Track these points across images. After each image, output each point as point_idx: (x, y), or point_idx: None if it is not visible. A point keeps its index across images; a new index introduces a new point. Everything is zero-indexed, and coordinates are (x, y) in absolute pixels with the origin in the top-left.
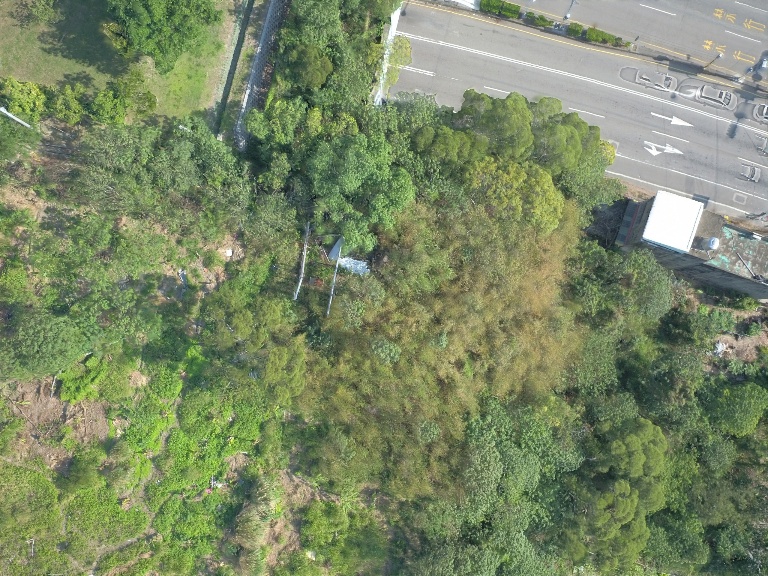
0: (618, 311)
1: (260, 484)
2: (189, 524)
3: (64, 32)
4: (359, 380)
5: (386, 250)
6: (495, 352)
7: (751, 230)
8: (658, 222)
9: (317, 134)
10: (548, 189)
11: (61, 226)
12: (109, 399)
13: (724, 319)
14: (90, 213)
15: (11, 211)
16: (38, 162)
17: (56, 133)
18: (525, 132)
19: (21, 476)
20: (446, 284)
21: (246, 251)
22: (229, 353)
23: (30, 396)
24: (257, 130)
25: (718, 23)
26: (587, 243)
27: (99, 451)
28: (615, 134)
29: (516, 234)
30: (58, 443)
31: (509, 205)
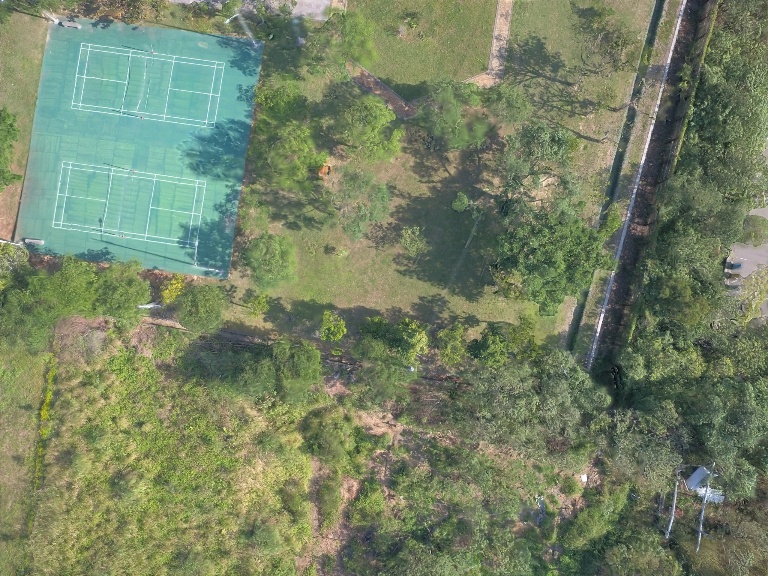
0: None
1: None
2: None
3: (419, 254)
4: None
5: (760, 491)
6: None
7: None
8: None
9: None
10: None
11: (417, 449)
12: None
13: None
14: (446, 437)
15: (370, 435)
16: None
17: None
18: None
19: None
20: None
21: (603, 478)
22: None
23: None
24: (639, 374)
25: None
26: None
27: None
28: None
29: None
30: None
31: None
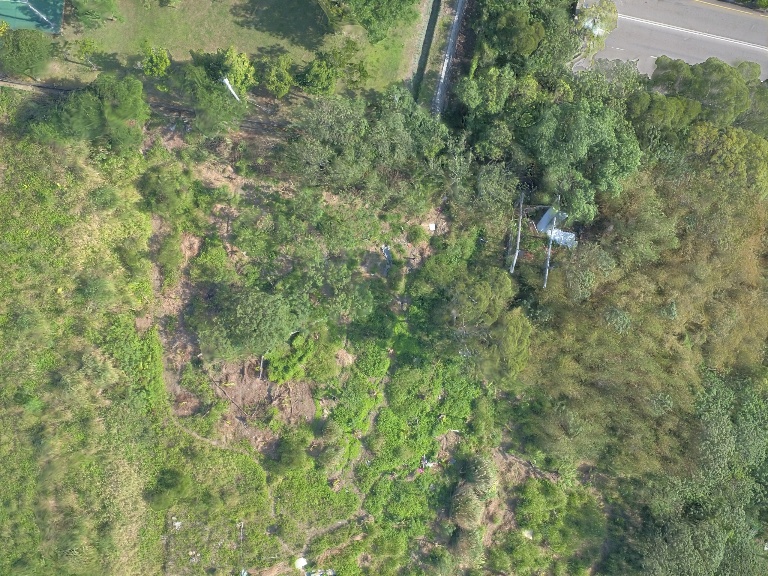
0: None
1: (478, 462)
2: (402, 504)
3: (256, 4)
4: (580, 354)
5: (605, 220)
6: (716, 323)
7: None
8: None
9: (531, 102)
10: None
11: (259, 203)
12: (316, 378)
13: None
14: (289, 189)
15: (209, 189)
16: (236, 138)
17: (252, 108)
18: (745, 95)
19: (228, 458)
20: (668, 254)
21: (451, 225)
22: (438, 329)
23: (234, 377)
24: (473, 99)
25: None
26: None
27: (307, 432)
28: None
29: (745, 200)
30: (265, 424)
31: (735, 170)
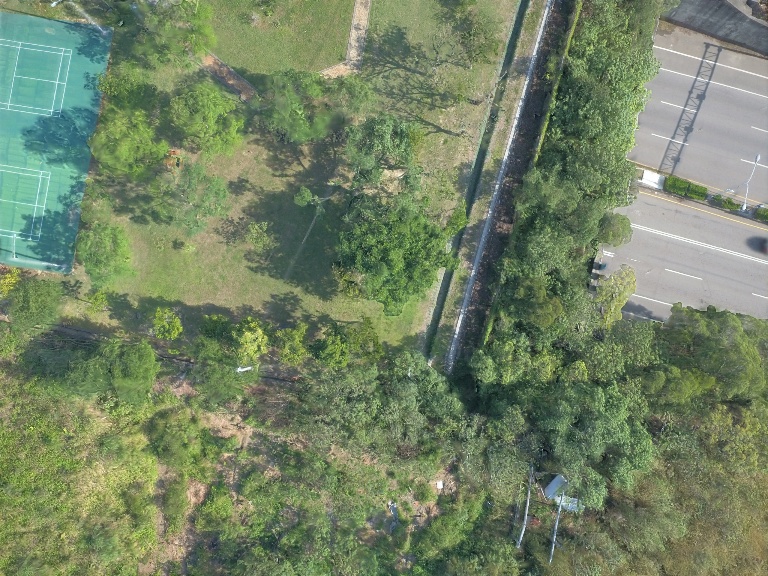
0: None
1: None
2: None
3: (271, 250)
4: None
5: (614, 501)
6: None
7: None
8: None
9: (545, 379)
10: None
11: (267, 453)
12: None
13: None
14: (297, 440)
15: (217, 438)
16: (246, 389)
17: (263, 357)
18: (760, 380)
19: None
20: (675, 537)
21: (459, 485)
22: None
23: None
24: (487, 377)
25: None
26: None
27: None
28: None
29: (755, 494)
30: None
31: (746, 462)
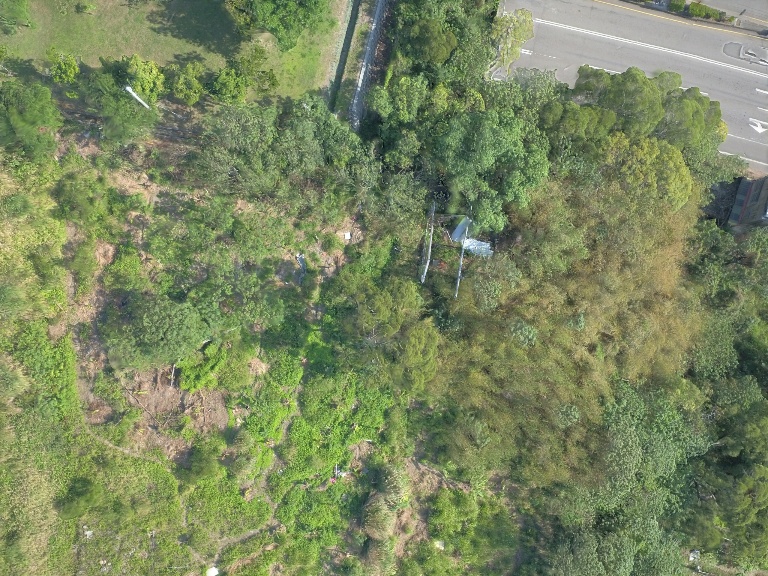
0: None
1: (388, 472)
2: (313, 514)
3: (173, 11)
4: (490, 364)
5: (516, 230)
6: (628, 334)
7: None
8: None
9: (443, 111)
10: (681, 165)
11: (174, 211)
12: (229, 387)
13: None
14: (204, 197)
15: (124, 196)
16: (151, 145)
17: (168, 115)
18: (657, 106)
19: (140, 467)
20: (578, 264)
21: (366, 234)
22: (351, 338)
23: (147, 385)
24: (383, 108)
25: None
26: (706, 222)
27: (219, 441)
28: None
29: (654, 211)
30: (177, 433)
31: (645, 181)
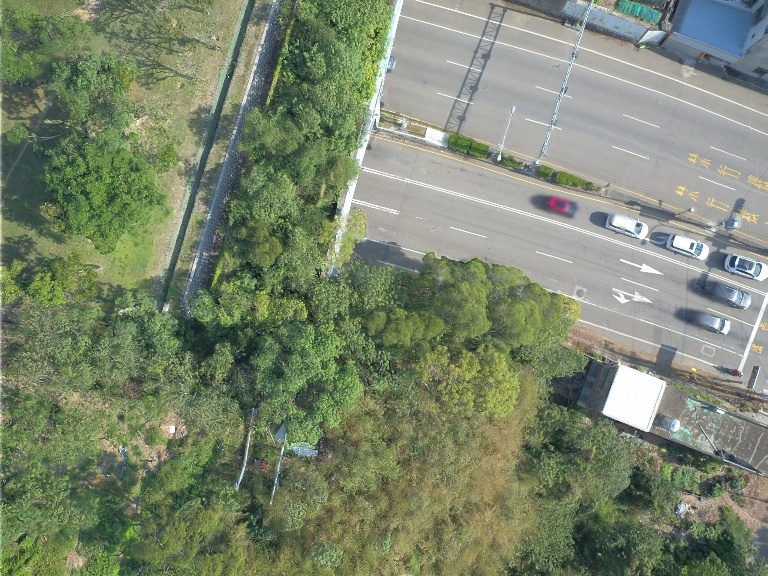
0: (576, 481)
1: None
2: None
3: (6, 193)
4: (301, 575)
5: (332, 441)
6: (443, 546)
7: (718, 384)
8: (619, 399)
9: (264, 319)
10: (502, 380)
11: None
12: None
13: (687, 478)
14: (29, 384)
15: None
16: None
17: None
18: (480, 321)
19: None
20: (393, 478)
21: (190, 429)
22: None
23: None
24: (201, 316)
25: (692, 168)
26: (546, 412)
27: None
28: (583, 280)
29: (466, 433)
30: None
31: (460, 401)
